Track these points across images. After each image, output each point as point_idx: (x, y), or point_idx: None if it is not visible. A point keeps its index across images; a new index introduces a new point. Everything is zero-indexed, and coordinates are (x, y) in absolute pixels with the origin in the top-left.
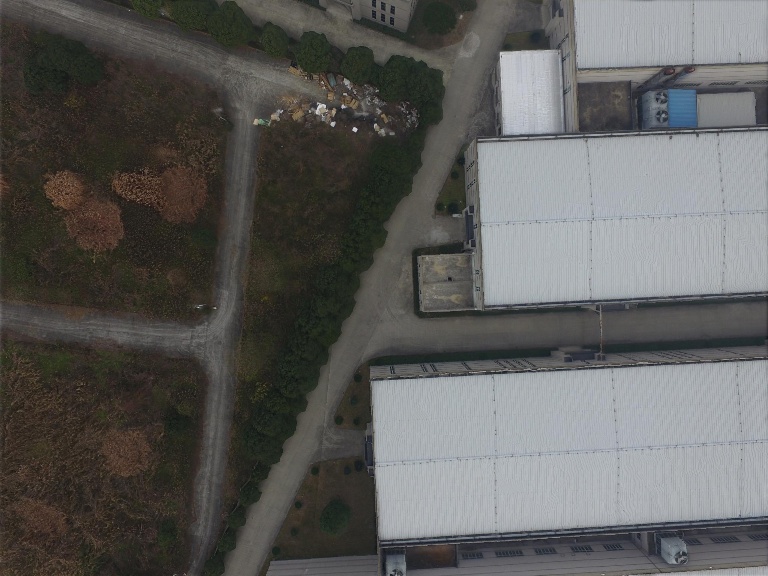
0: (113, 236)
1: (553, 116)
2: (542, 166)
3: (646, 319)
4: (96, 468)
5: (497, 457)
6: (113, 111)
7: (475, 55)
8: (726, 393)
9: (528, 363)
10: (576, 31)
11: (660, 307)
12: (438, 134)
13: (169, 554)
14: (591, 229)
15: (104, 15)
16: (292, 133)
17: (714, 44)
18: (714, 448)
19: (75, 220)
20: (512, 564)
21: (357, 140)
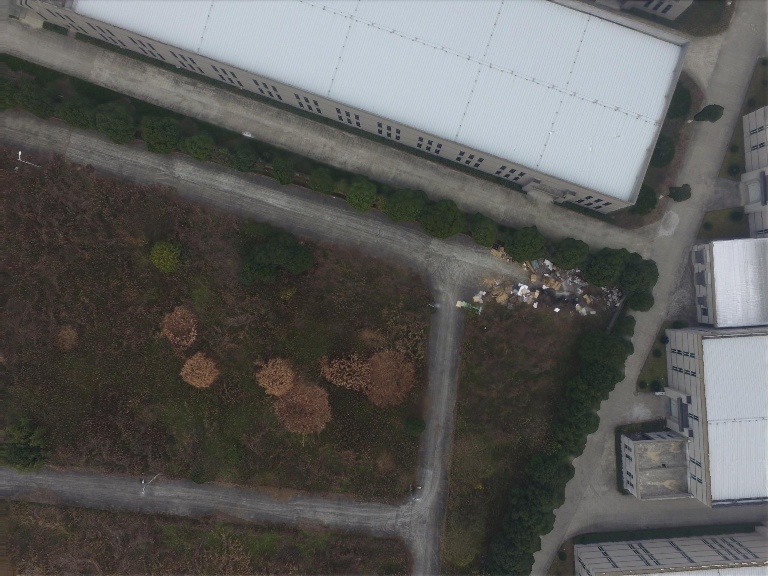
0: (320, 418)
1: (766, 303)
2: (766, 362)
3: None
4: None
5: None
6: (321, 297)
7: (674, 233)
8: None
9: (745, 549)
10: None
11: None
12: (639, 312)
13: None
14: None
15: (309, 203)
16: (496, 315)
17: None
18: None
19: (284, 405)
20: None
21: (558, 320)
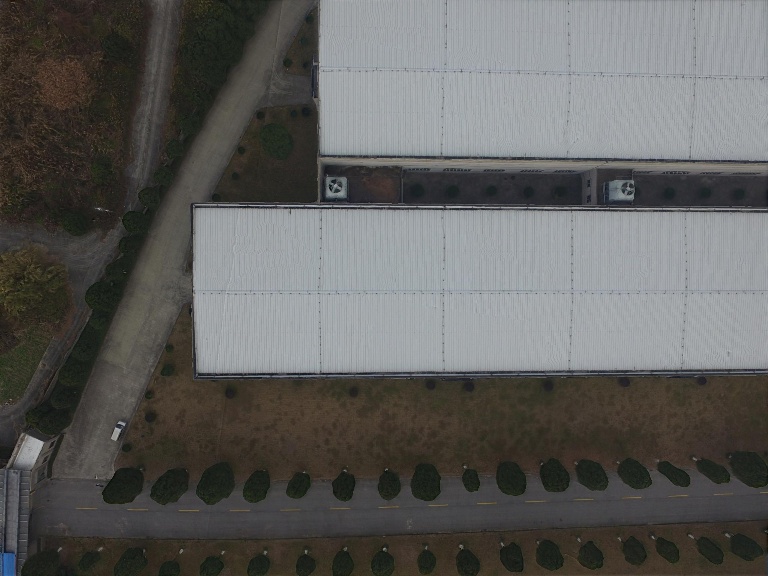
0: None
1: None
2: None
3: None
4: (29, 95)
5: (446, 71)
6: None
7: None
8: (682, 26)
9: None
10: None
11: None
12: None
13: (103, 193)
14: None
15: None
16: None
17: None
18: (667, 80)
19: None
20: None
21: None
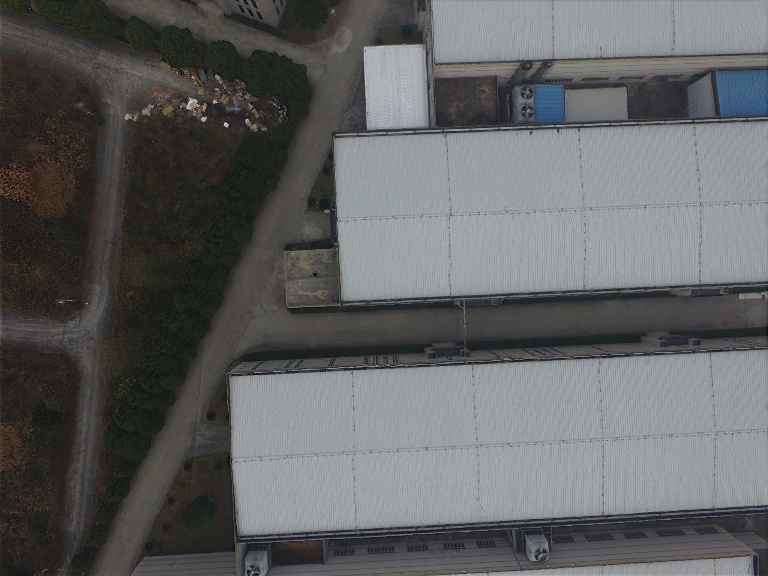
0: None
1: (418, 111)
2: (400, 161)
3: (521, 316)
4: None
5: (355, 453)
6: None
7: (347, 50)
8: (588, 390)
9: (393, 359)
10: (434, 25)
11: (535, 304)
12: (310, 129)
13: (41, 549)
14: (449, 225)
15: None
16: (162, 128)
17: (575, 39)
18: (575, 445)
19: None
20: (379, 561)
21: (229, 135)
